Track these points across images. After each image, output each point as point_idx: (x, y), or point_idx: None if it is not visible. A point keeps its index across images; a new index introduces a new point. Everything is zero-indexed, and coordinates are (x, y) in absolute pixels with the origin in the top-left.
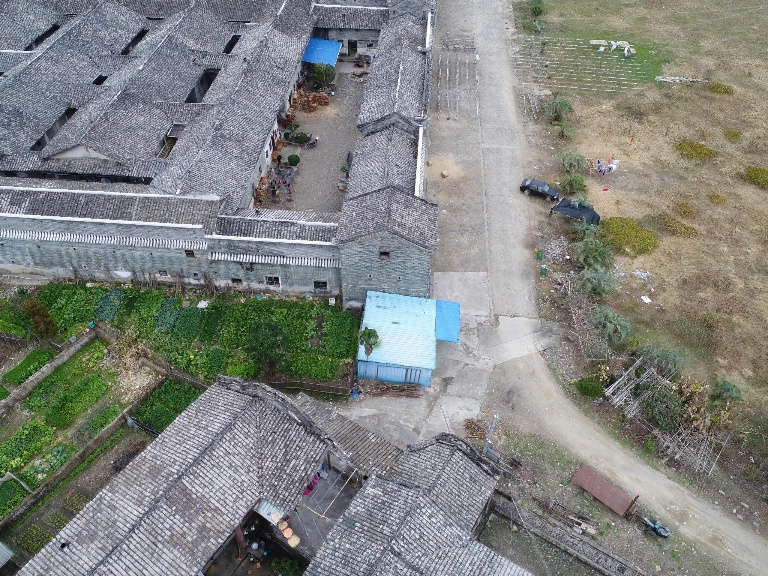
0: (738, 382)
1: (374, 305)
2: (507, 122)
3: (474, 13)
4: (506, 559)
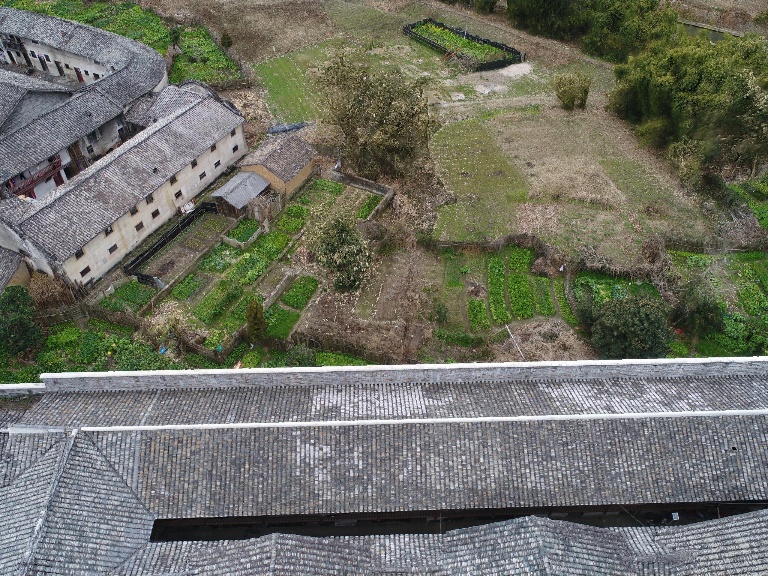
0: None
1: None
2: None
3: None
4: None
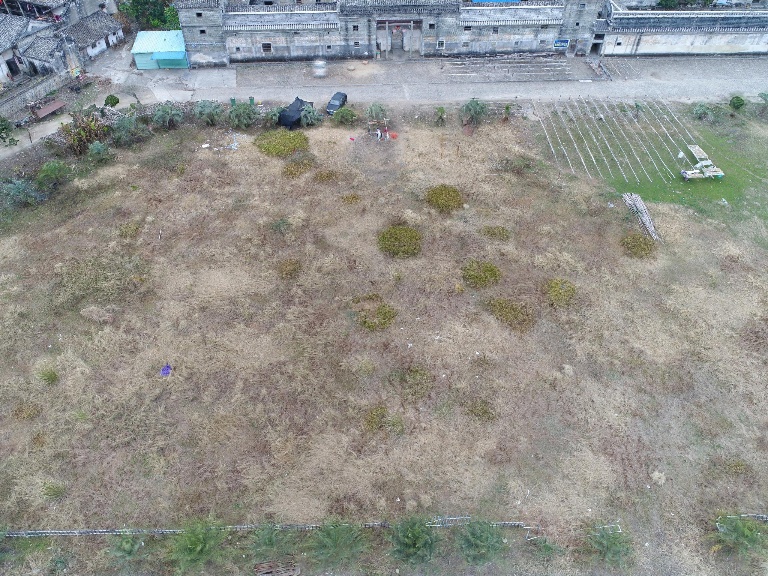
0: (116, 173)
1: (179, 33)
2: (453, 95)
3: (714, 79)
4: (1, 51)
